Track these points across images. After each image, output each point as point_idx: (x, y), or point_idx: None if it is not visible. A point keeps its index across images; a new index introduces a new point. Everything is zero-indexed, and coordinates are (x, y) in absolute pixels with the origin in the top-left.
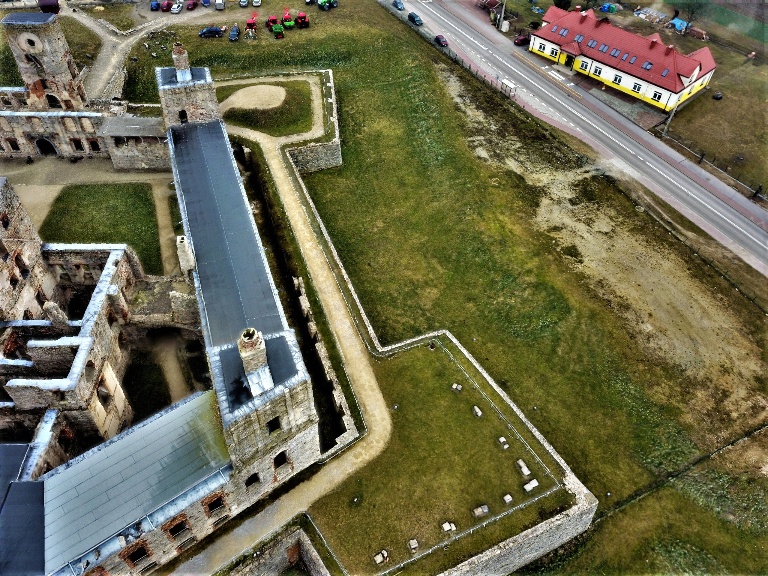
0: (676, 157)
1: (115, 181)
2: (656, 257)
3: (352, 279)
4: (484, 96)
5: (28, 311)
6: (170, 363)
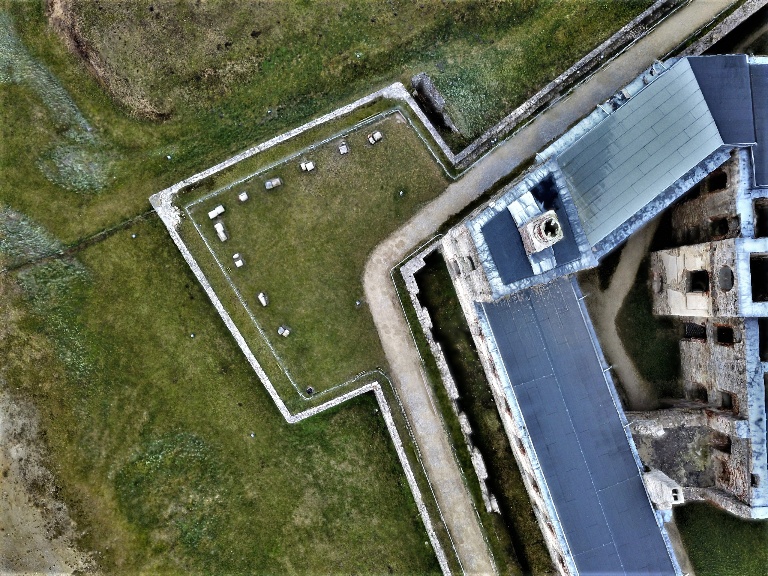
0: None
1: None
2: None
3: (415, 540)
4: None
5: None
6: (632, 383)
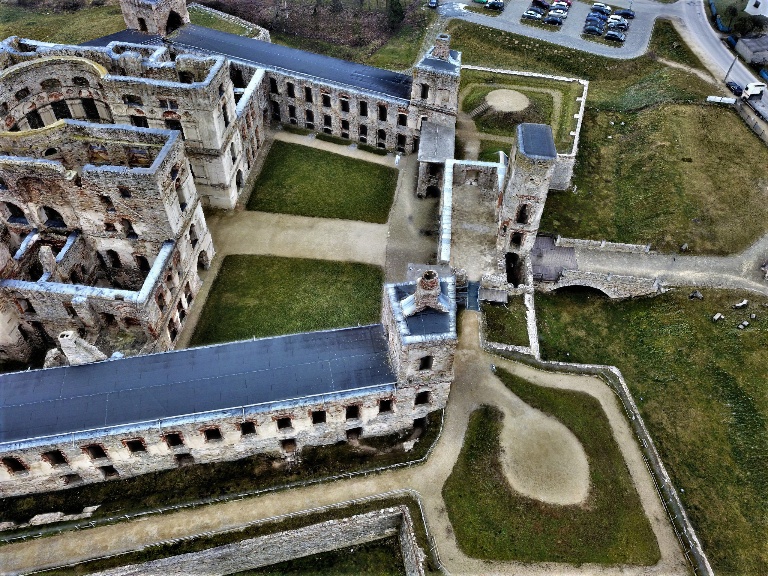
0: None
1: None
2: None
3: None
4: None
5: (118, 254)
6: None
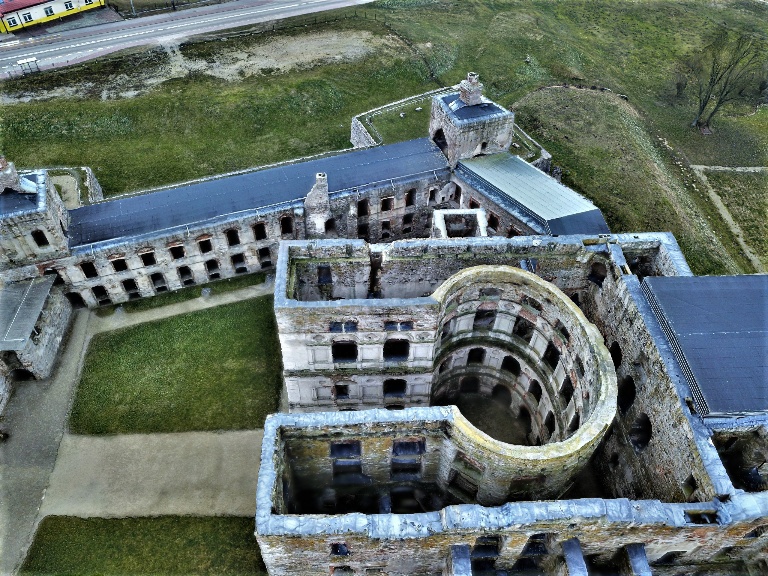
0: (164, 16)
1: (76, 374)
2: (276, 43)
3: None
4: (28, 84)
5: None
6: None
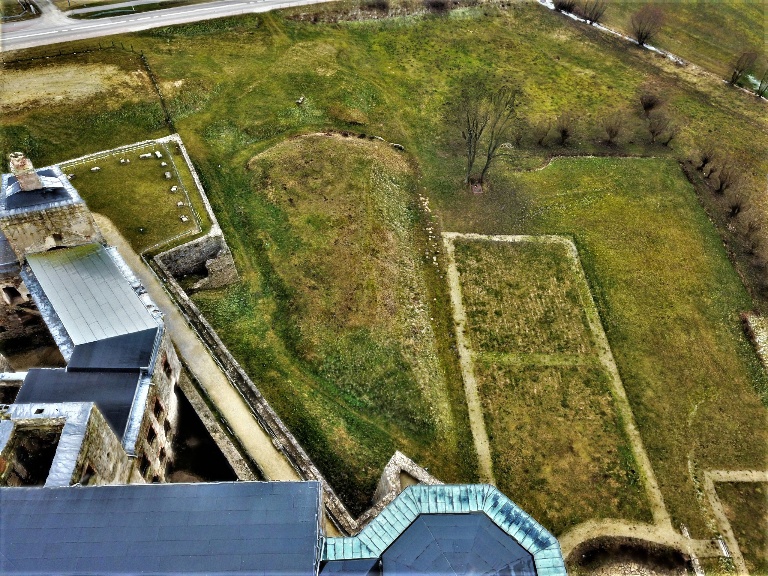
0: None
1: None
2: None
3: None
4: None
5: None
6: None
